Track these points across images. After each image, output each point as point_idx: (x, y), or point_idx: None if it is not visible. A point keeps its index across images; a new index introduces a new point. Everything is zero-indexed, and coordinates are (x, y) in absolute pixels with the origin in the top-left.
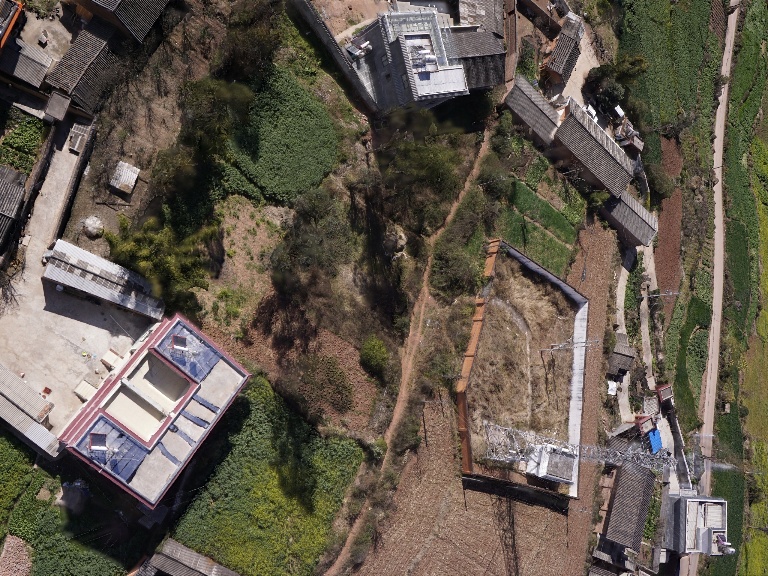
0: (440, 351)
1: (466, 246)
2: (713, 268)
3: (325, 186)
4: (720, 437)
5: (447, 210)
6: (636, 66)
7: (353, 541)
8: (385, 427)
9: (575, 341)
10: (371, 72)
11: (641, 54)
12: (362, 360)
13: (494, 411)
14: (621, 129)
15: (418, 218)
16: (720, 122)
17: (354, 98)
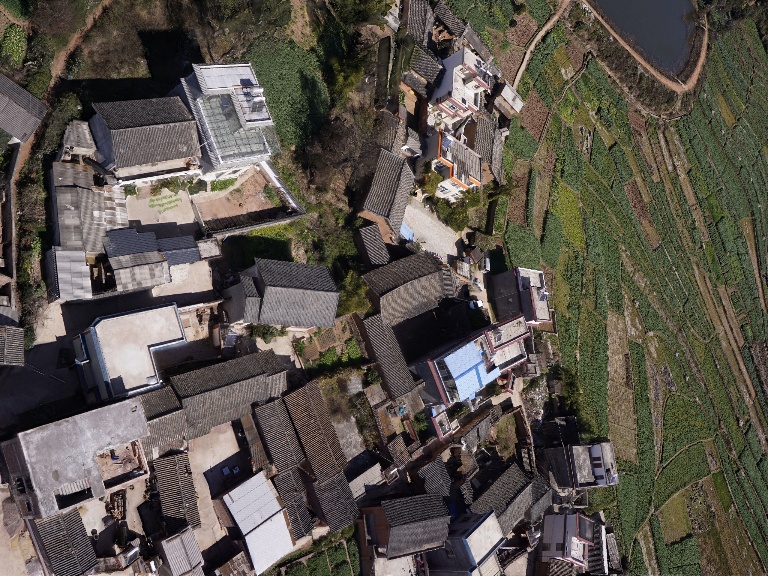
0: None
1: None
2: None
3: None
4: None
5: None
6: None
7: None
8: None
9: None
10: None
11: None
12: None
13: None
14: None
15: None
16: None
17: None
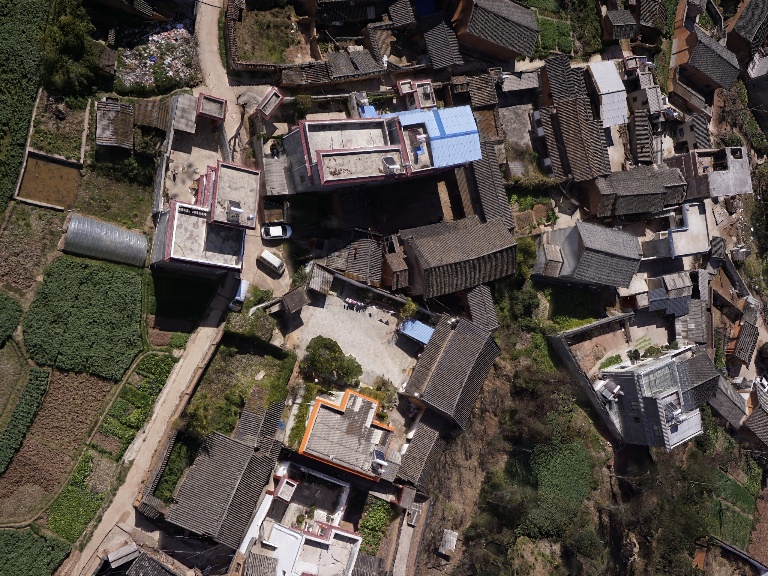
0: None
1: None
2: None
3: (584, 515)
4: None
5: None
6: None
7: None
8: None
9: None
10: (619, 410)
11: None
12: None
13: None
14: None
15: (648, 526)
16: None
17: (600, 427)
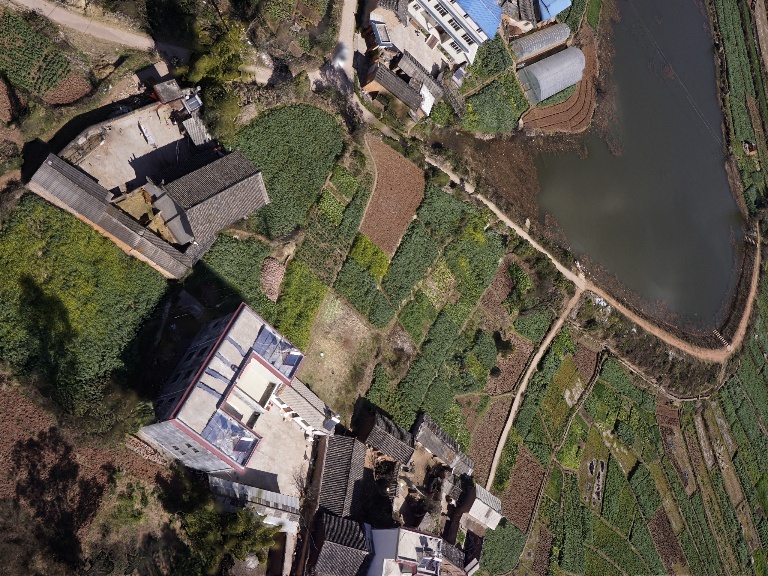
0: None
1: None
2: None
3: None
4: None
5: None
6: None
7: None
8: None
9: None
10: None
11: None
12: None
13: None
14: None
15: None
16: None
17: None
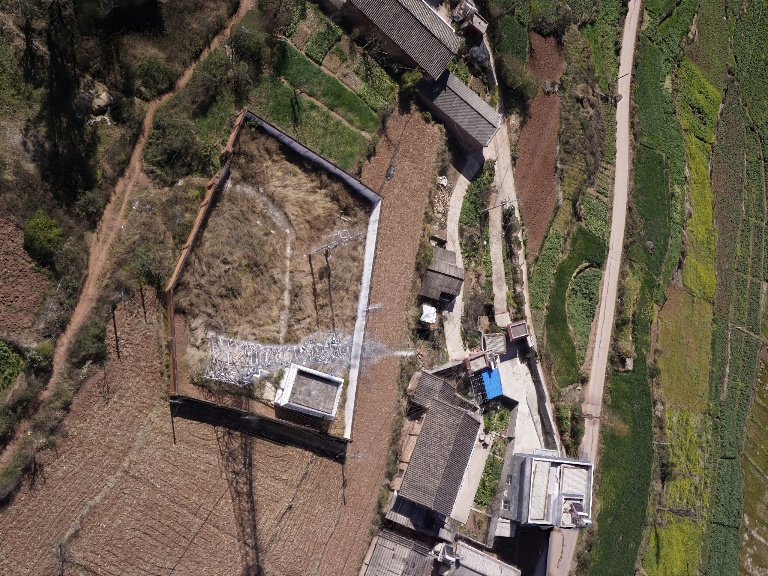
0: (147, 240)
1: (203, 117)
2: (612, 198)
3: None
4: (616, 397)
5: (171, 68)
6: None
7: (1, 473)
8: (57, 330)
9: (366, 249)
10: None
11: None
12: (25, 243)
13: (225, 321)
14: (458, 7)
15: (126, 74)
16: (630, 32)
17: None
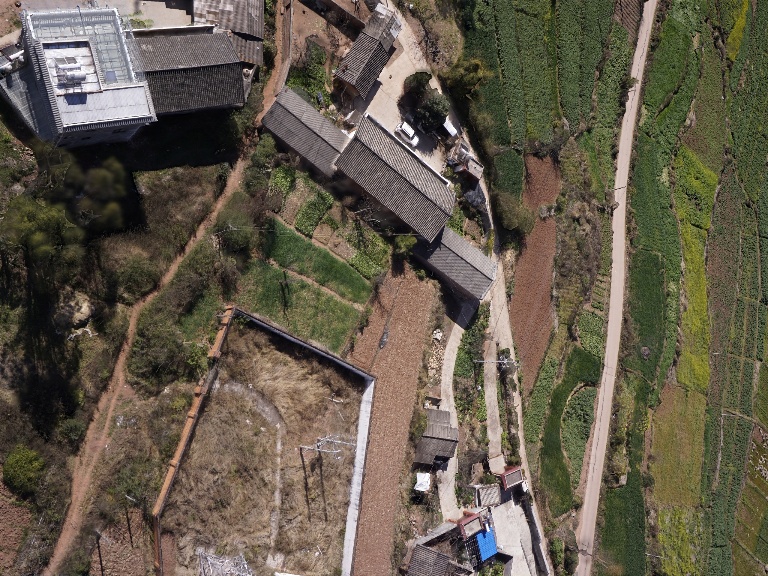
0: (132, 459)
1: (189, 315)
2: (608, 311)
3: None
4: (610, 516)
5: (155, 270)
6: (471, 72)
7: None
8: (40, 566)
9: (359, 429)
10: (29, 91)
11: (496, 55)
12: (5, 479)
13: (214, 535)
14: (453, 151)
15: (107, 283)
16: (627, 133)
17: (17, 125)
